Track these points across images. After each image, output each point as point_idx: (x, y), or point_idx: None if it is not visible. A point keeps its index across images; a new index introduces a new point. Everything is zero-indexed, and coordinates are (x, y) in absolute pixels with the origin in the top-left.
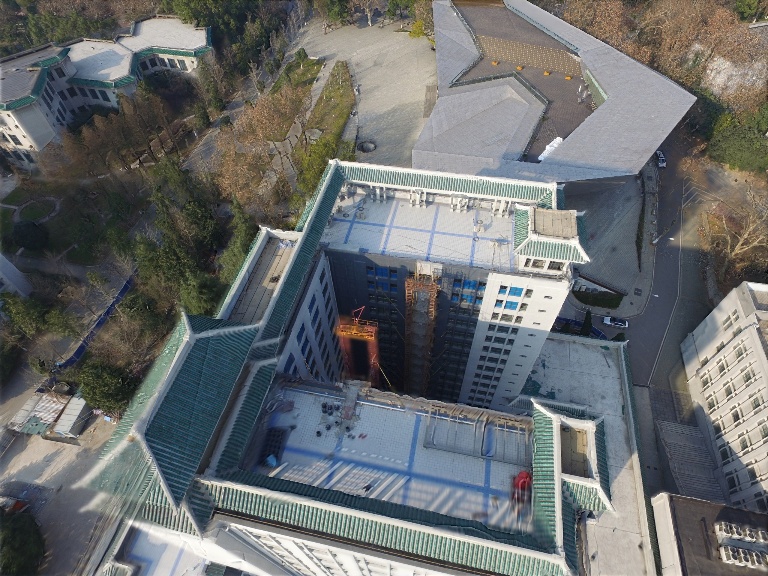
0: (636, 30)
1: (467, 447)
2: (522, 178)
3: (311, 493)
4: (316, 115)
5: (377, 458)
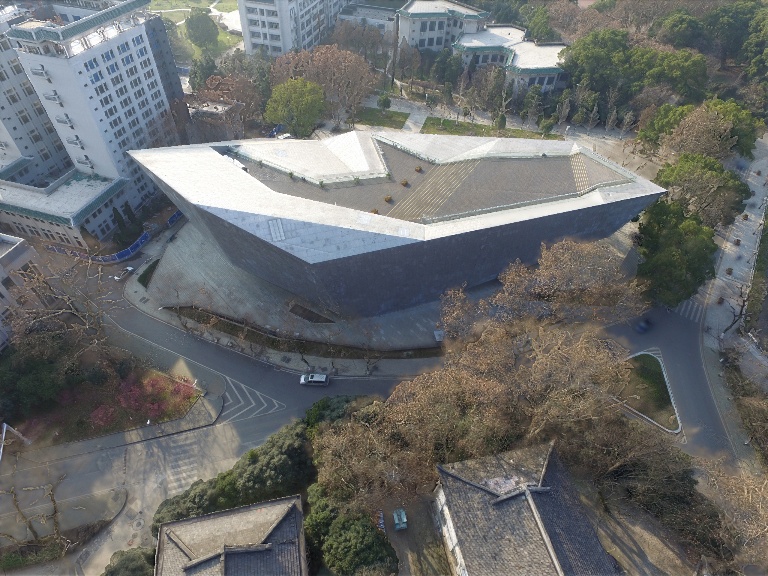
0: None
1: None
2: (205, 144)
3: None
4: None
5: None
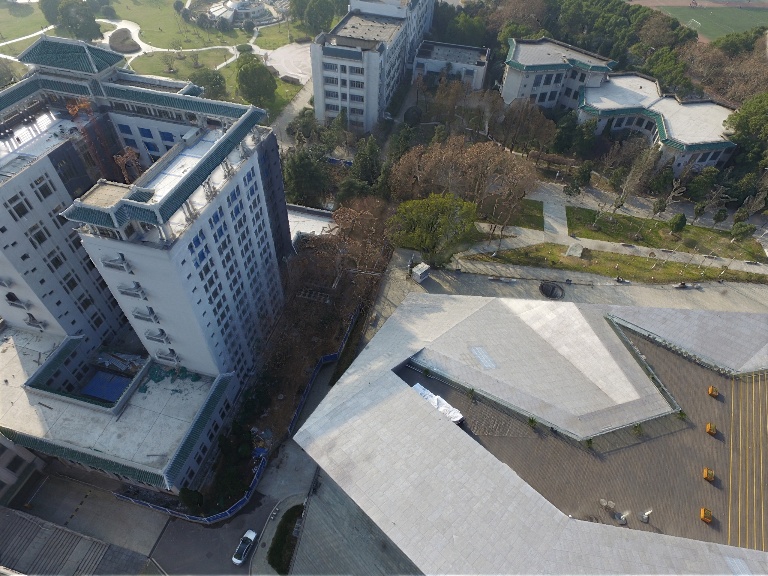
0: None
1: (4, 169)
2: (374, 354)
3: (6, 99)
4: (625, 257)
5: (30, 143)
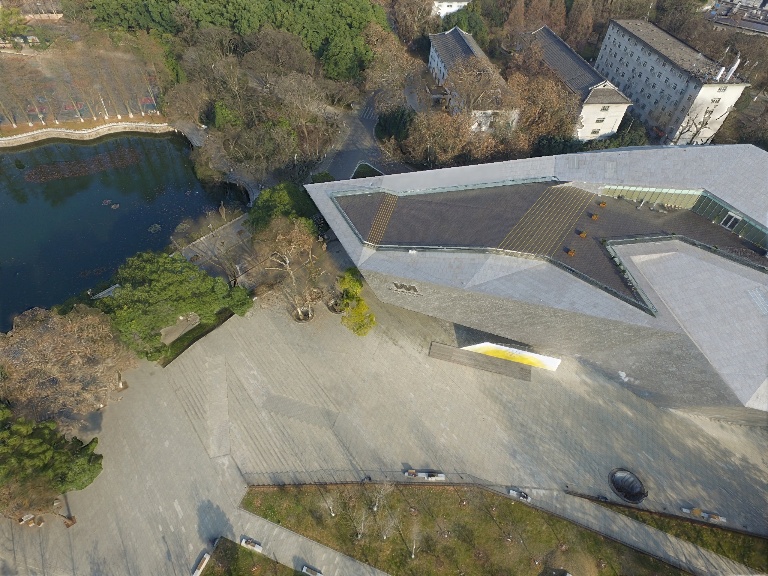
0: (339, 131)
1: None
2: None
3: None
4: None
5: None
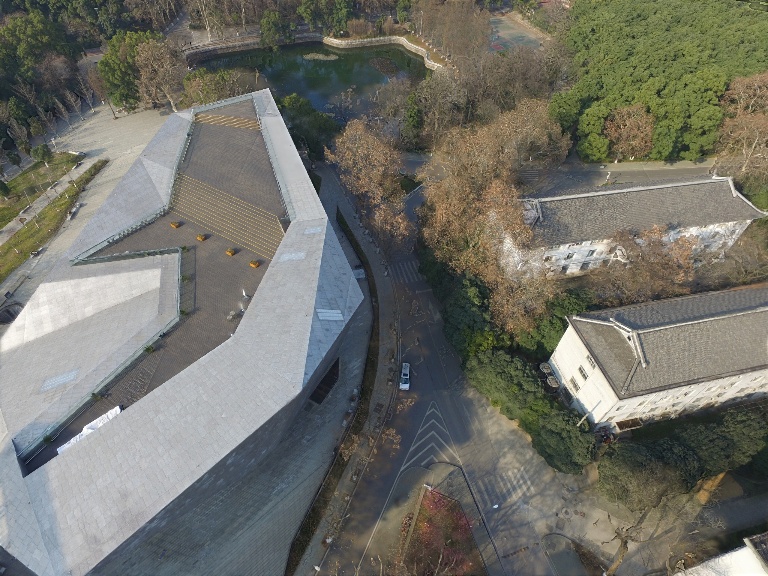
0: None
1: None
2: None
3: None
4: (10, 242)
5: None
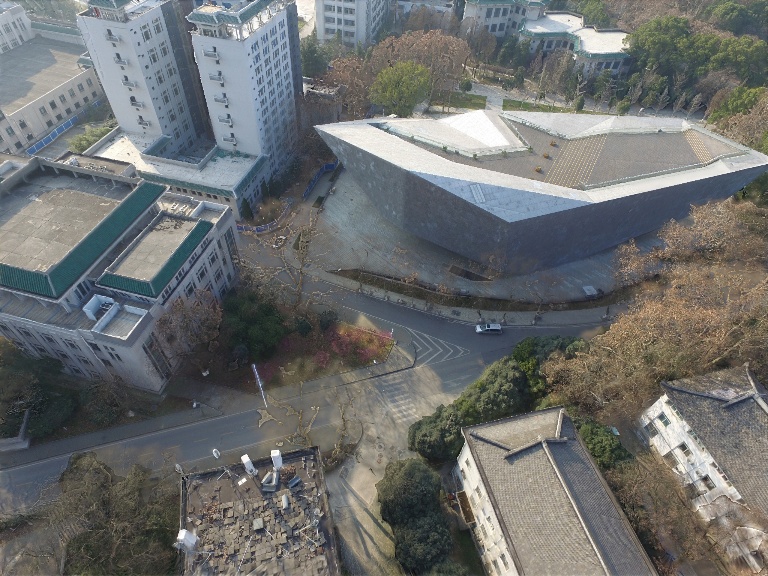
0: None
1: None
2: None
3: None
4: None
5: None
